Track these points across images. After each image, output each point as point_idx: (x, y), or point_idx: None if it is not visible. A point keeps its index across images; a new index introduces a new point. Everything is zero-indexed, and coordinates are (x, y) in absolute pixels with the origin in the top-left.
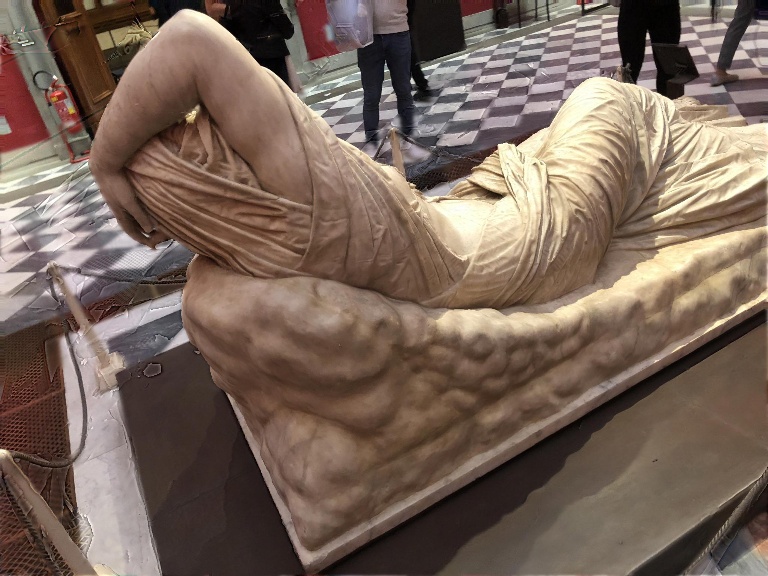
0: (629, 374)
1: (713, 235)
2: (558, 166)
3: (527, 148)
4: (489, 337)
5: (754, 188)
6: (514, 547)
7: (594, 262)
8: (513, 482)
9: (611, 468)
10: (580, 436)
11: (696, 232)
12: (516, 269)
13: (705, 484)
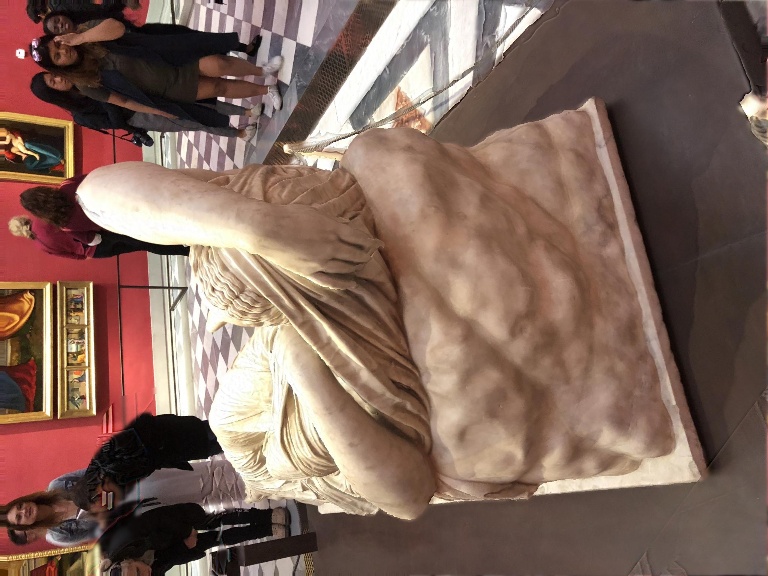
0: None
1: None
2: None
3: None
4: None
5: None
6: (494, 127)
7: None
8: None
9: None
10: None
11: None
12: None
13: None
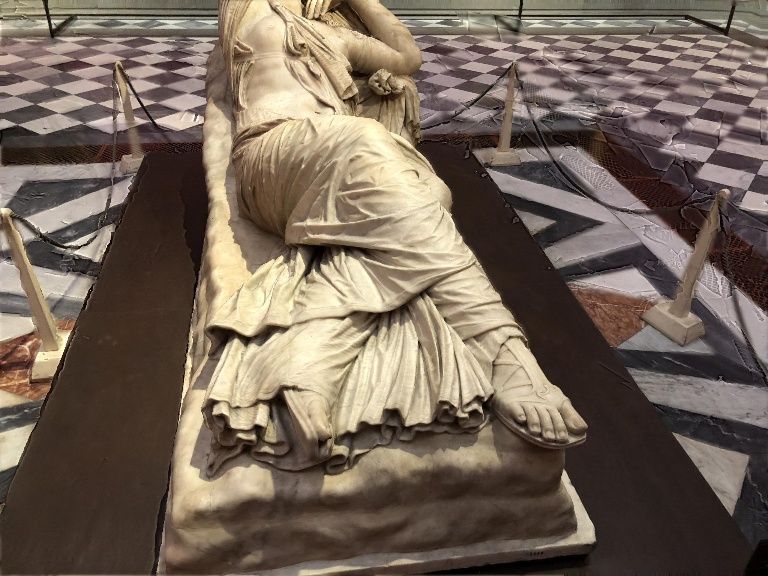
0: None
1: None
2: None
3: None
4: (203, 135)
5: None
6: (166, 219)
7: None
8: (201, 230)
9: (164, 259)
10: (199, 259)
11: None
12: None
13: (111, 281)
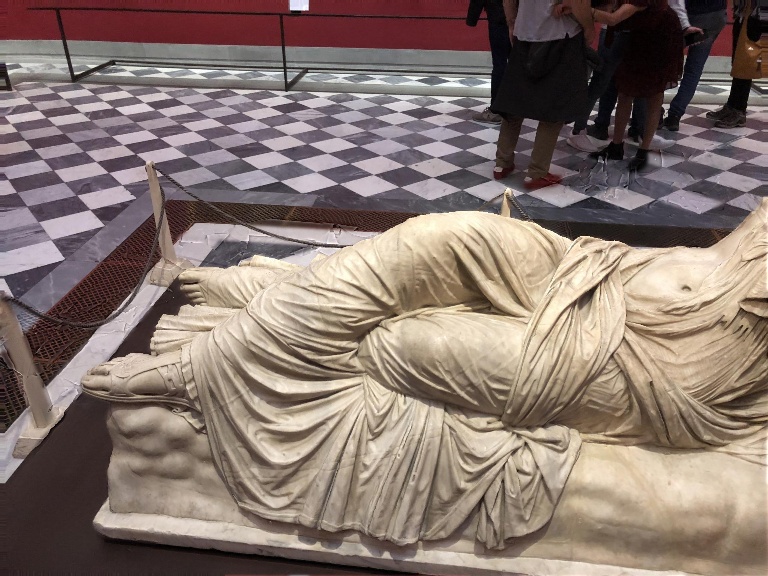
0: None
1: None
2: None
3: (505, 326)
4: None
5: None
6: None
7: None
8: None
9: None
10: None
11: None
12: None
13: None
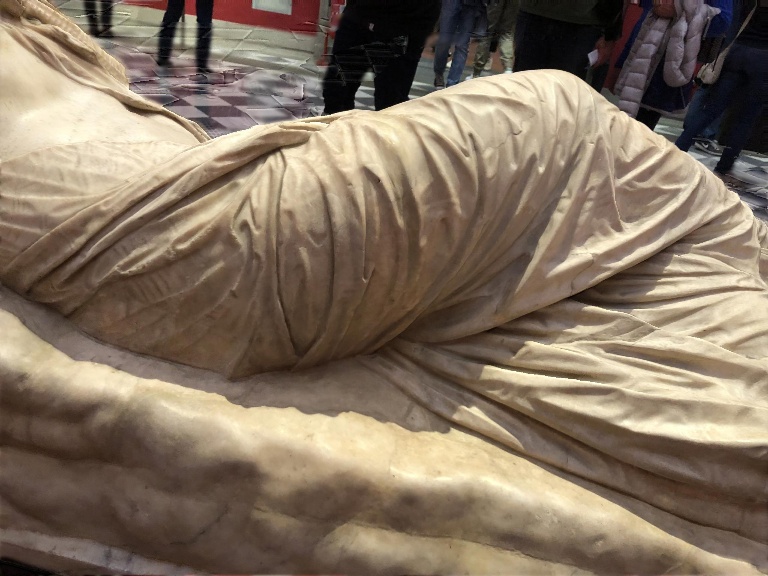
0: (170, 575)
1: (575, 481)
2: (306, 144)
3: None
4: None
5: (715, 451)
6: None
7: (243, 342)
8: None
9: None
10: None
11: (546, 451)
12: (40, 238)
13: None
